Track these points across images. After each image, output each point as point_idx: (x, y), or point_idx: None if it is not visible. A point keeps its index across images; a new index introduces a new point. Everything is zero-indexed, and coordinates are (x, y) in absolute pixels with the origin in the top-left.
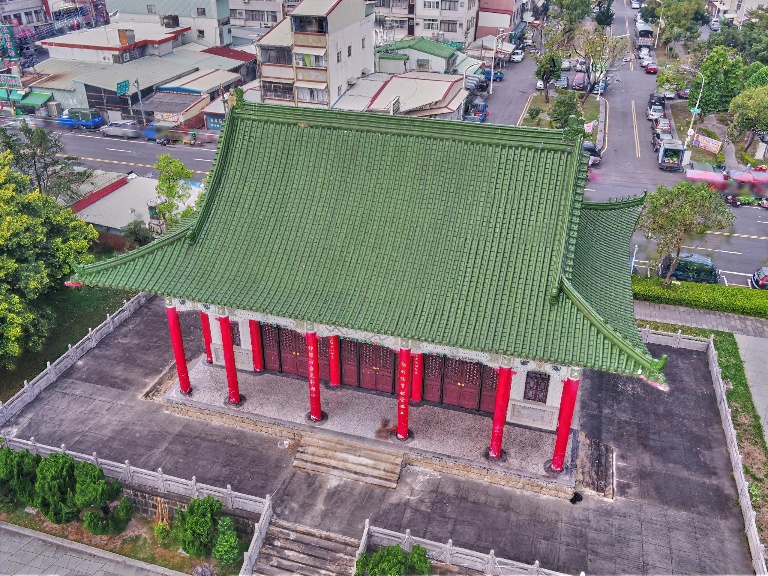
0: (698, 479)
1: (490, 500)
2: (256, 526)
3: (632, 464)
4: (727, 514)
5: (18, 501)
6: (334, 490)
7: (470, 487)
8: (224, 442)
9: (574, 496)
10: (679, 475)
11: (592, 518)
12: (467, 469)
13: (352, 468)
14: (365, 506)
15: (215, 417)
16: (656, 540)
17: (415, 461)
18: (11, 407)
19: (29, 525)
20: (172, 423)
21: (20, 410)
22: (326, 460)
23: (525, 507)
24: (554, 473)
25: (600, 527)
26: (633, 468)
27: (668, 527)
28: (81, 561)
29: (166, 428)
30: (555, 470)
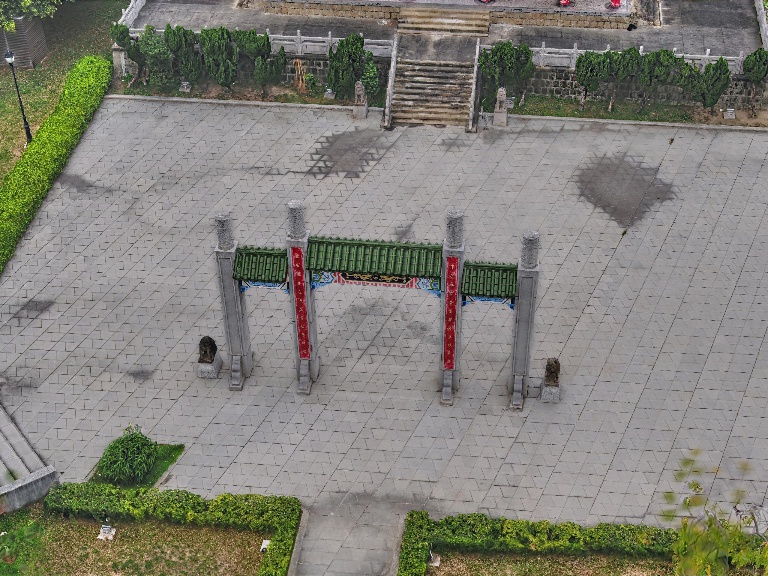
0: (727, 11)
1: (565, 35)
2: (393, 54)
3: (675, 8)
4: (747, 26)
5: (168, 87)
6: (439, 41)
7: (547, 30)
8: (331, 26)
9: (630, 24)
10: (712, 10)
11: (645, 36)
12: (543, 17)
13: (448, 27)
14: (467, 47)
15: (315, 10)
16: (693, 42)
17: (499, 18)
18: (129, 18)
19: (191, 97)
20: (277, 19)
21: (132, 24)
22: (425, 25)
23: (593, 36)
24: (614, 9)
25: (651, 40)
26: (675, 10)
27: (702, 36)
28: (250, 109)
29: (274, 22)
30: (614, 6)
